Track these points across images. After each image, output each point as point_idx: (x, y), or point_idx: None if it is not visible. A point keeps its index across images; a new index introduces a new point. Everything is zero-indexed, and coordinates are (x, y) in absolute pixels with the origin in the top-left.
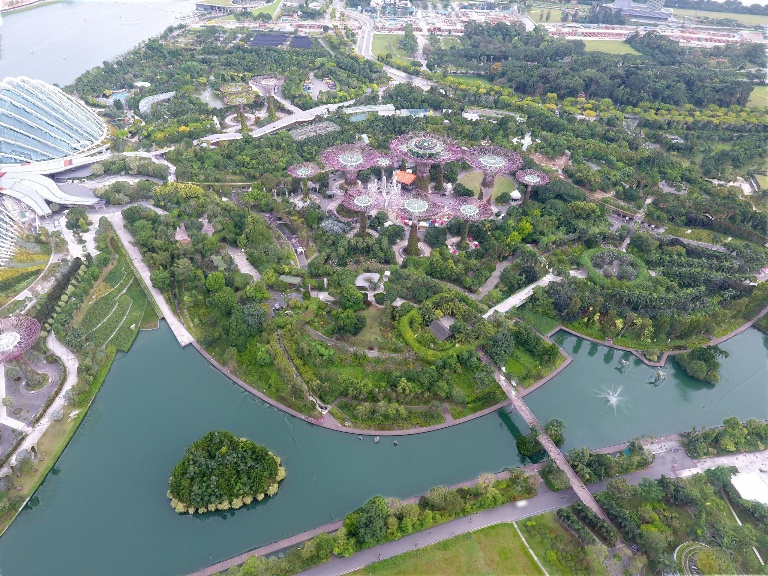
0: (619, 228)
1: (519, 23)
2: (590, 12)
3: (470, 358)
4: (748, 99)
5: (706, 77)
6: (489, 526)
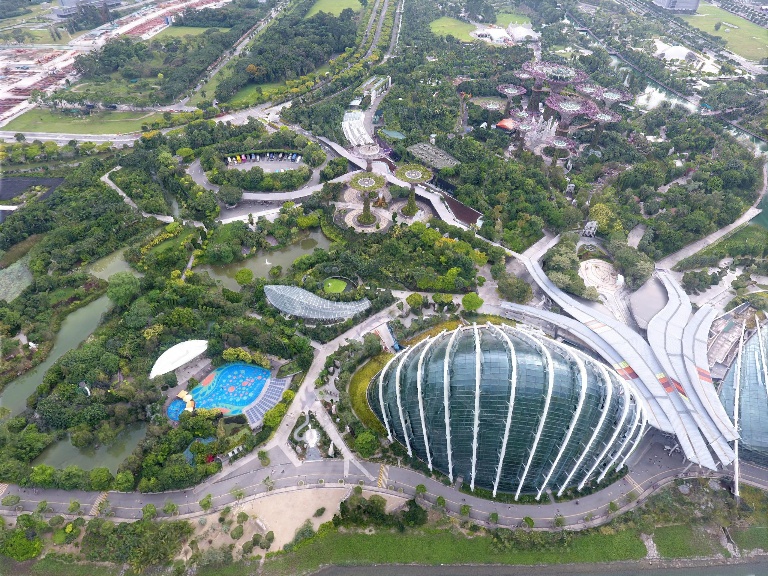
0: None
1: (114, 40)
2: (82, 16)
3: None
4: None
5: (323, 16)
6: None
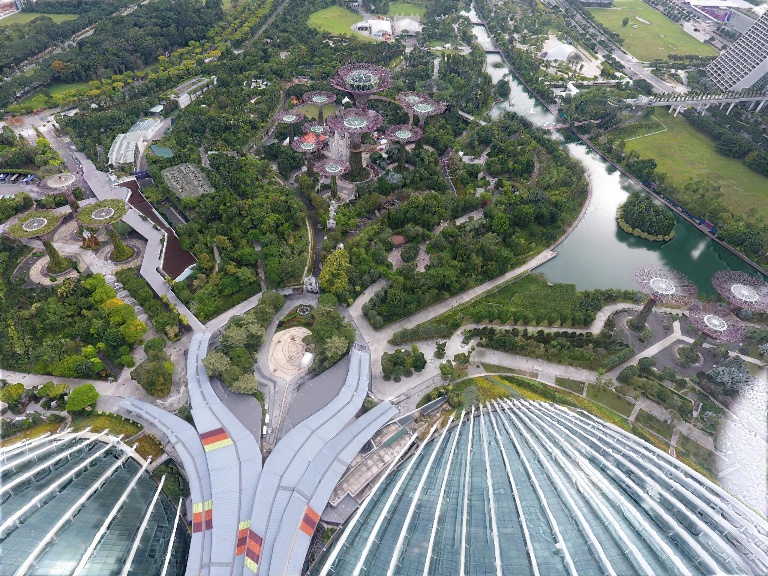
0: (396, 77)
1: None
2: None
3: (535, 131)
4: (221, 8)
5: (185, 3)
6: None
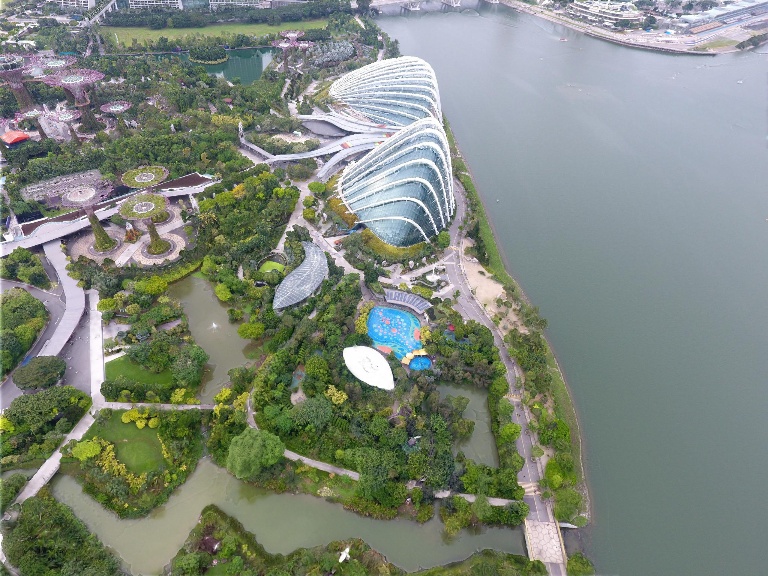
0: None
1: None
2: None
3: None
4: None
5: None
6: None
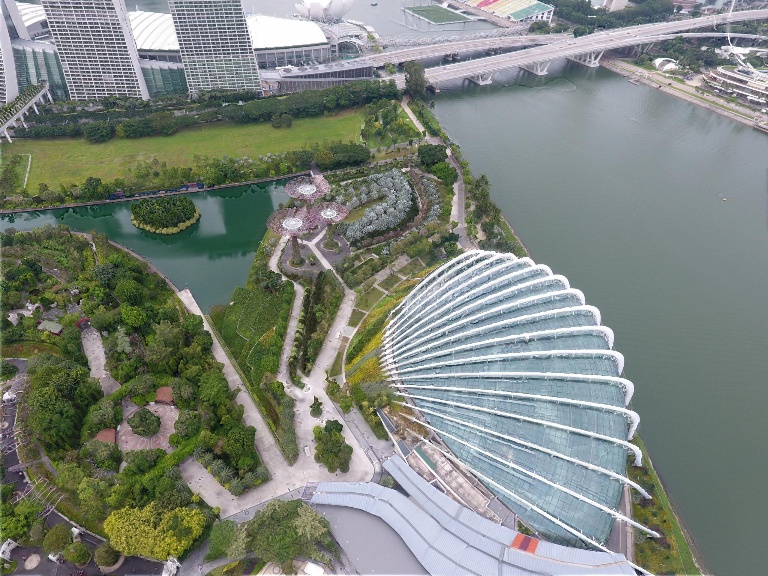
0: None
1: None
2: None
3: None
4: None
5: None
6: (35, 195)
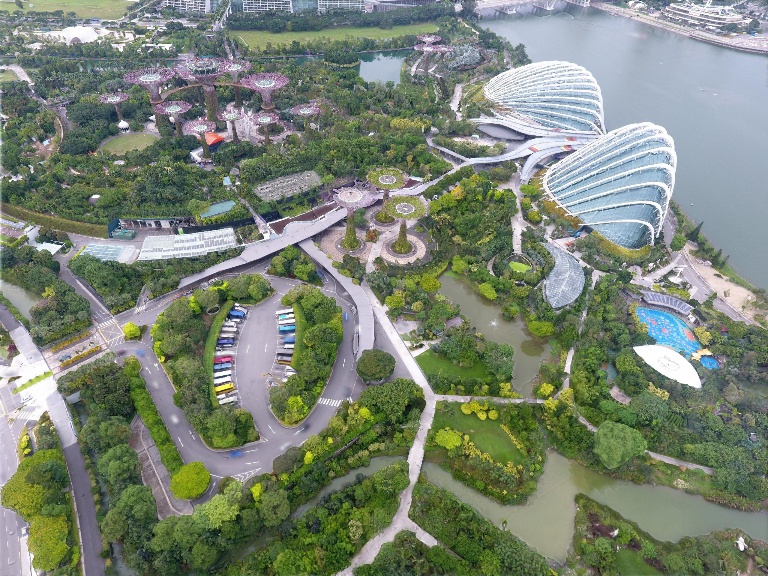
0: None
1: None
2: None
3: None
4: None
5: None
6: None
